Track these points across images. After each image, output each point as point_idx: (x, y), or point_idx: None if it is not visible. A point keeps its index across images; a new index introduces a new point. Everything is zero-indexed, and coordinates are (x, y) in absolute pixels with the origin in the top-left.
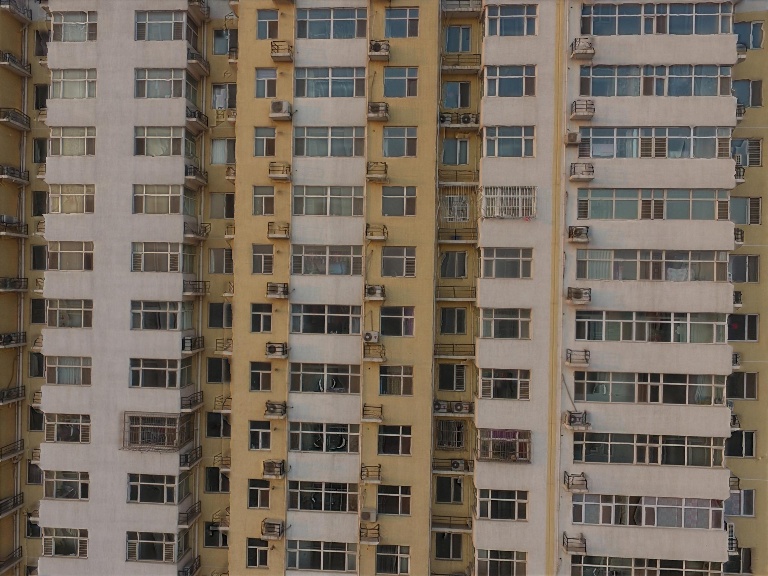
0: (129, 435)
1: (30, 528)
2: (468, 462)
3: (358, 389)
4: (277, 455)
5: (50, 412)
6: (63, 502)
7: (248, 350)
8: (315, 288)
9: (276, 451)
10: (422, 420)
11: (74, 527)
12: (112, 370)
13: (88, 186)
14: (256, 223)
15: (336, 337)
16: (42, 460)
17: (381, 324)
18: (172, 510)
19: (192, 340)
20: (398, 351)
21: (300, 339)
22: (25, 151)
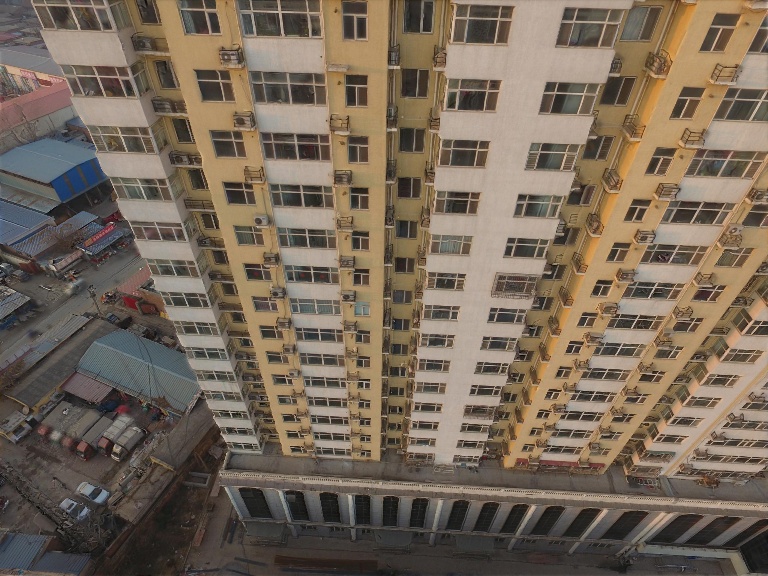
0: (496, 286)
1: (393, 325)
2: (746, 298)
3: (697, 261)
4: (612, 300)
5: (433, 272)
6: (439, 322)
7: (617, 235)
8: (701, 188)
9: (612, 298)
10: (740, 283)
11: (446, 334)
12: (491, 246)
13: (492, 81)
14: (670, 128)
15: (700, 227)
16: (425, 299)
17: (746, 217)
18: (521, 327)
19: (566, 225)
20: (749, 238)
21: (667, 228)
22: (396, 19)
